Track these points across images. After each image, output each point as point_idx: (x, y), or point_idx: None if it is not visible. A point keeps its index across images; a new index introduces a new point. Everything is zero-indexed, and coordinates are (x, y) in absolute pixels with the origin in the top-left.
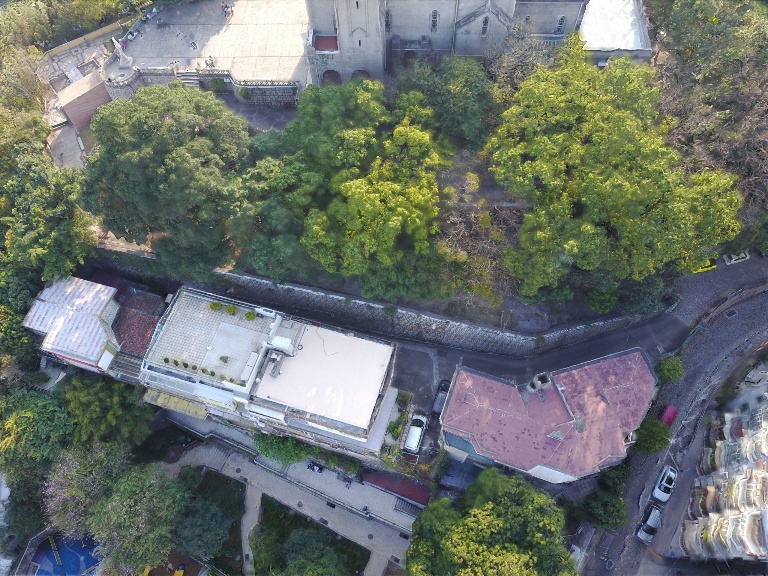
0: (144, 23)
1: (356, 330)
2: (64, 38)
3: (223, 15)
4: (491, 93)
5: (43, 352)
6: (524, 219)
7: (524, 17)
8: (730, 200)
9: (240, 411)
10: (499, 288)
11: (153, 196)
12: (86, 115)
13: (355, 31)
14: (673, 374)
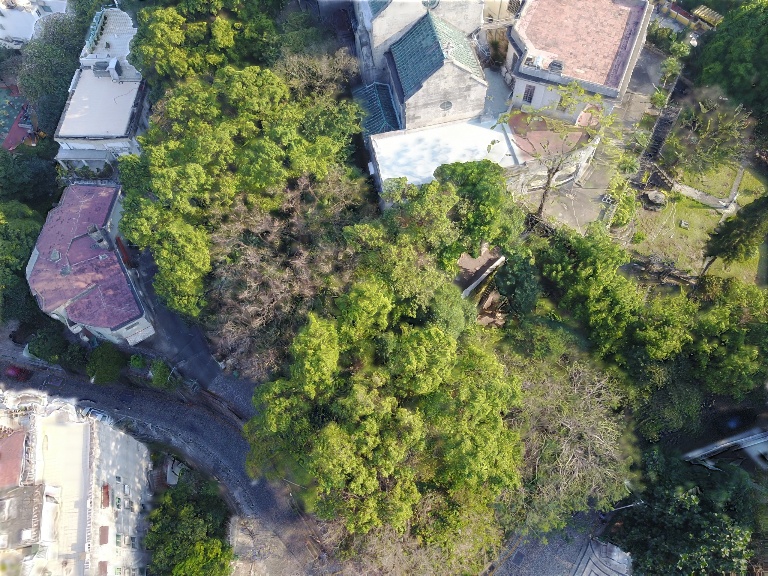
0: None
1: None
2: None
3: None
4: None
5: None
6: None
7: None
8: None
9: None
10: None
11: None
12: None
13: None
14: None
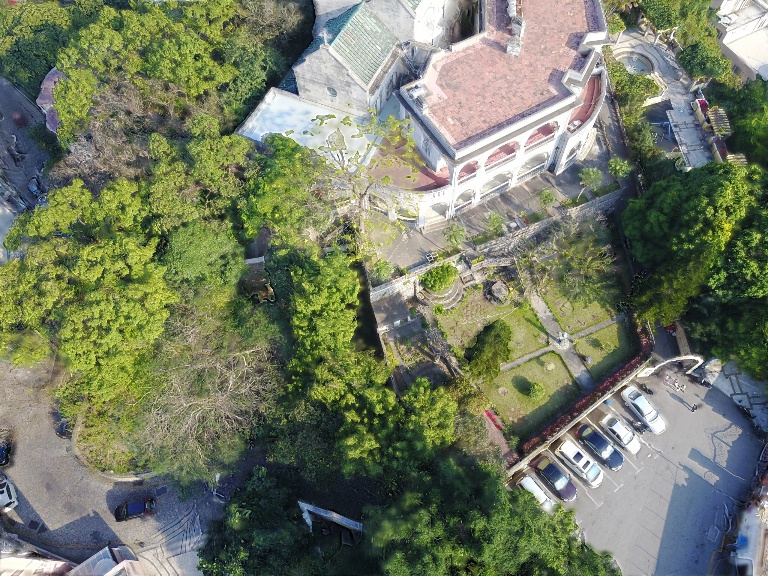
0: None
1: None
2: None
3: None
4: None
5: None
6: None
7: None
8: None
9: None
10: None
11: None
12: None
13: None
14: None
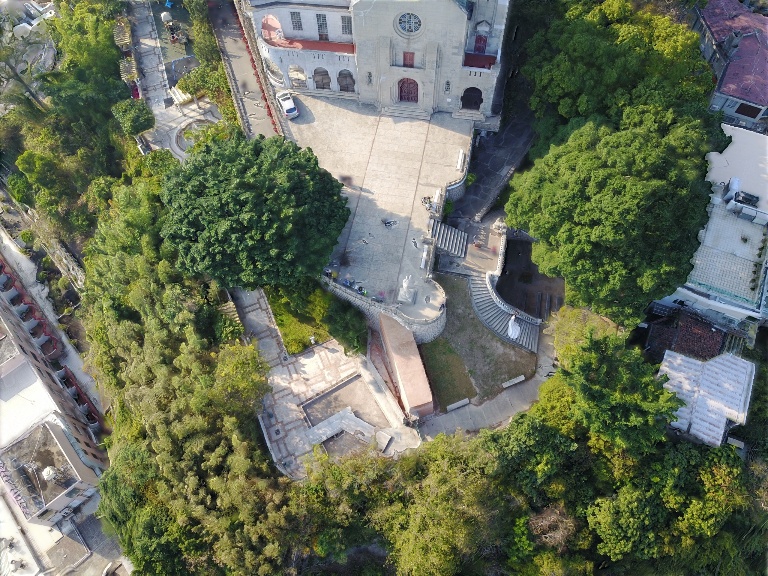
0: (335, 280)
1: None
2: None
3: None
4: None
5: None
6: None
7: None
8: None
9: None
10: None
11: None
12: None
13: None
14: None
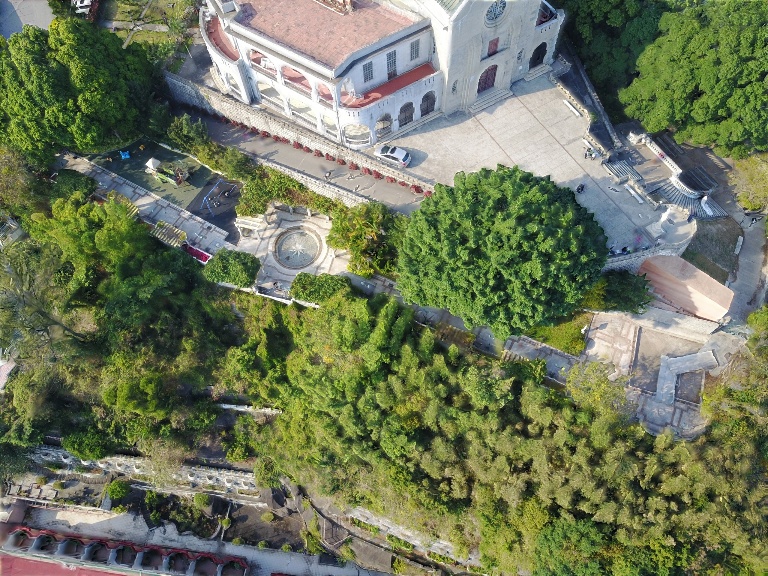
0: None
1: None
2: None
3: None
4: None
5: None
6: None
7: None
8: None
9: None
10: None
11: None
12: None
13: None
14: None
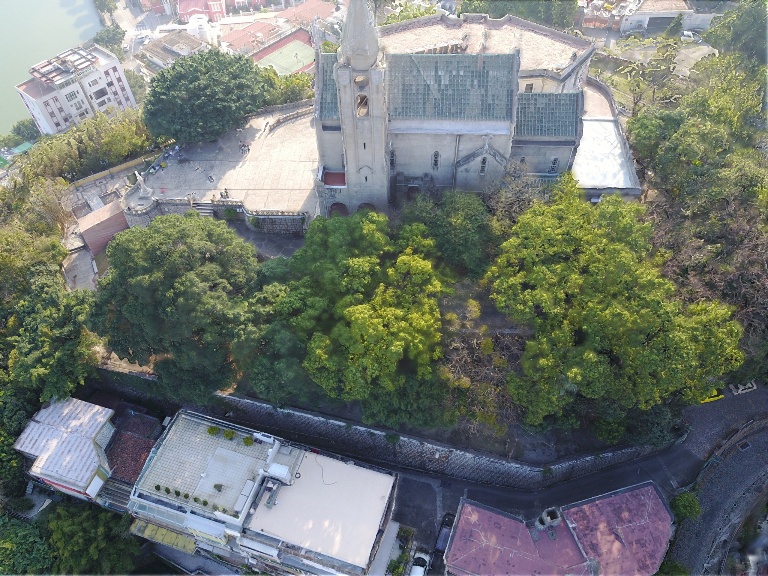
0: (166, 159)
1: (356, 458)
2: (91, 171)
3: (240, 153)
4: (490, 225)
5: (31, 476)
6: (526, 346)
7: (520, 158)
8: (730, 330)
9: (231, 545)
10: (503, 416)
11: (160, 318)
12: (103, 240)
13: (362, 168)
14: (690, 511)
